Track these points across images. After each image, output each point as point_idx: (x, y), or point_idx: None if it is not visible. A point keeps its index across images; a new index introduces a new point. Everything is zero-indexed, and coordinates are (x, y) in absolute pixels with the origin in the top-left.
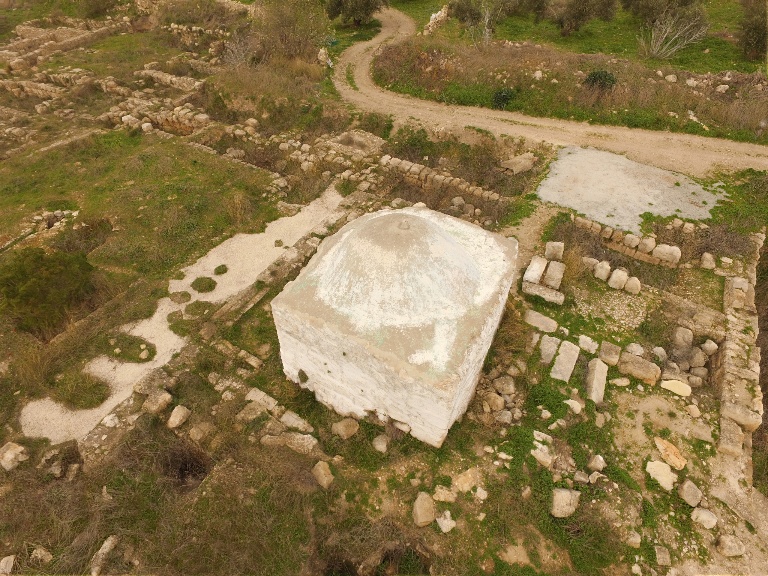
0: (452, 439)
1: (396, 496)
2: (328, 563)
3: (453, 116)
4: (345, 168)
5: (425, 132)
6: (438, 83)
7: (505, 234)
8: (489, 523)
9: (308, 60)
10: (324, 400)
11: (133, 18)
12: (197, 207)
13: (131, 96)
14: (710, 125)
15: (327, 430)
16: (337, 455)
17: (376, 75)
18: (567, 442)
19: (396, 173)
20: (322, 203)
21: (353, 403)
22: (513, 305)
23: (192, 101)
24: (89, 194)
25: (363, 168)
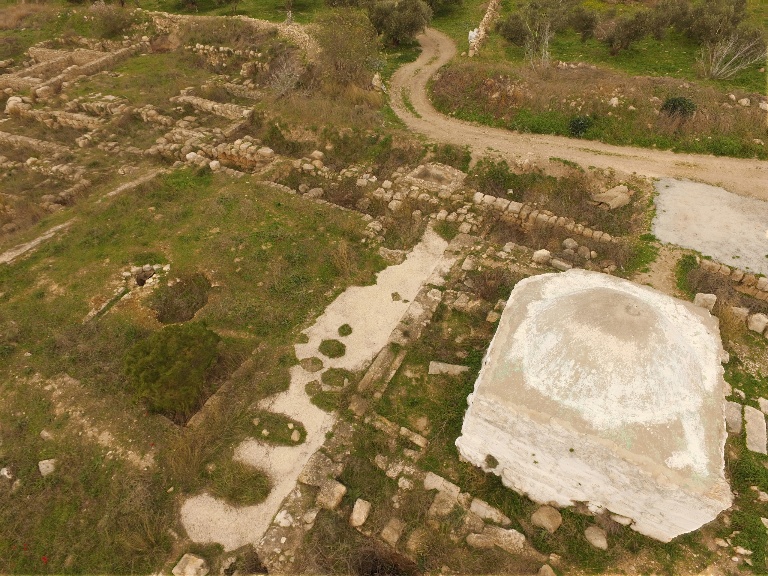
0: None
1: None
2: None
3: (532, 146)
4: (433, 205)
5: (506, 164)
6: (507, 110)
7: (639, 282)
8: None
9: (362, 86)
10: (517, 487)
11: (152, 37)
12: (298, 257)
13: (175, 126)
14: None
15: (527, 521)
16: (552, 553)
17: (437, 101)
18: None
19: (492, 211)
20: (426, 248)
21: (557, 493)
22: None
23: (242, 130)
24: (175, 245)
25: (458, 207)
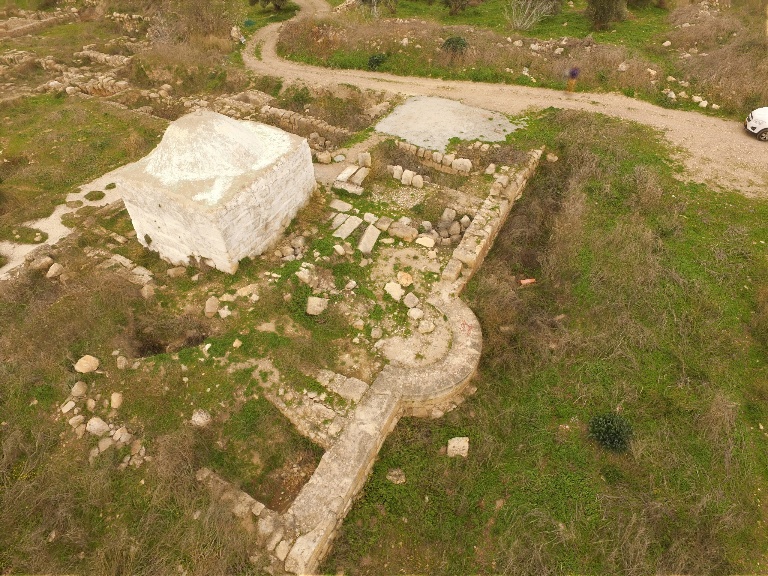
0: (244, 269)
1: (196, 302)
2: (143, 343)
3: (333, 77)
4: None
5: (307, 90)
6: (326, 52)
7: (337, 153)
8: (255, 313)
9: (222, 37)
10: (163, 255)
11: (80, 9)
12: (100, 145)
13: None
14: (538, 78)
15: (163, 274)
16: (164, 285)
17: (278, 48)
18: (332, 273)
19: (273, 119)
20: None
21: (180, 252)
22: (319, 193)
23: (121, 74)
24: (13, 139)
25: (246, 116)
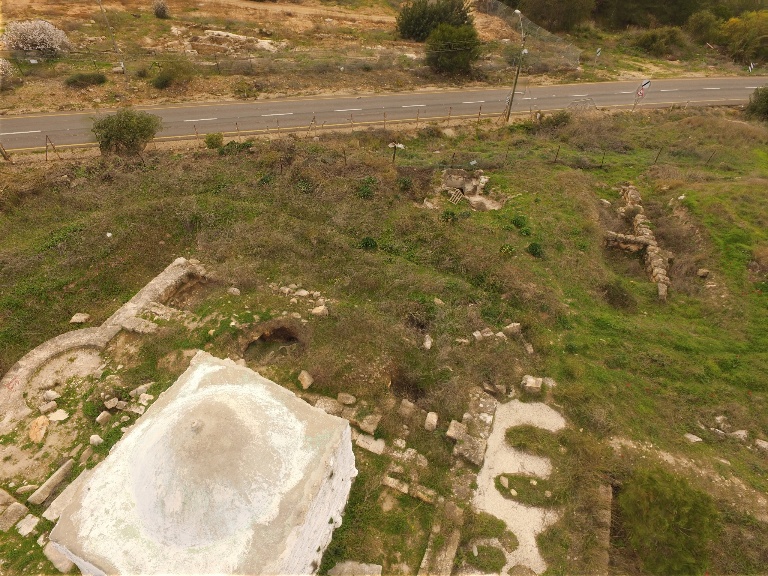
0: None
1: None
2: None
3: None
4: None
5: None
6: None
7: None
8: None
9: None
10: None
11: None
12: None
13: None
14: None
15: None
16: None
17: None
18: None
19: None
20: None
21: None
22: None
23: None
24: None
25: None
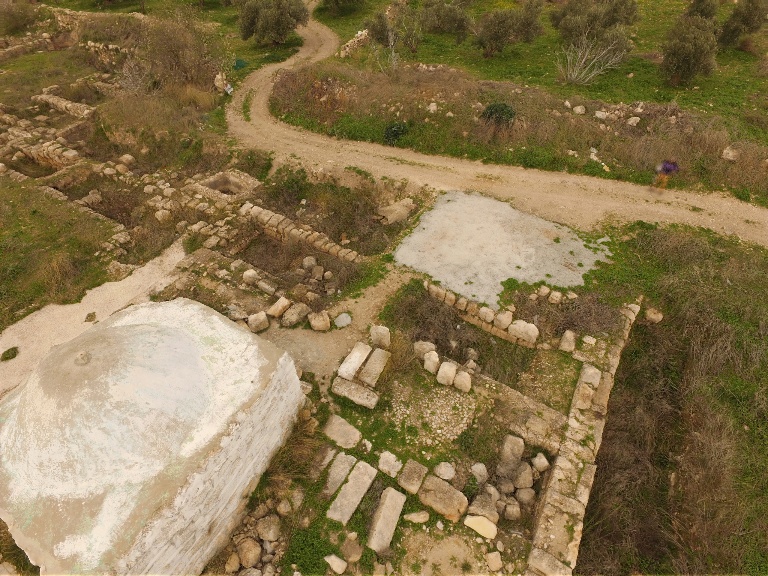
0: None
1: None
2: None
3: (338, 153)
4: (207, 216)
5: (305, 172)
6: (331, 115)
7: (339, 309)
8: None
9: (204, 87)
10: None
11: (54, 34)
12: (12, 271)
13: (17, 125)
14: (611, 165)
15: None
16: None
17: (271, 104)
18: None
19: (255, 224)
20: (160, 263)
21: None
22: (308, 413)
23: (79, 131)
24: None
25: (219, 219)
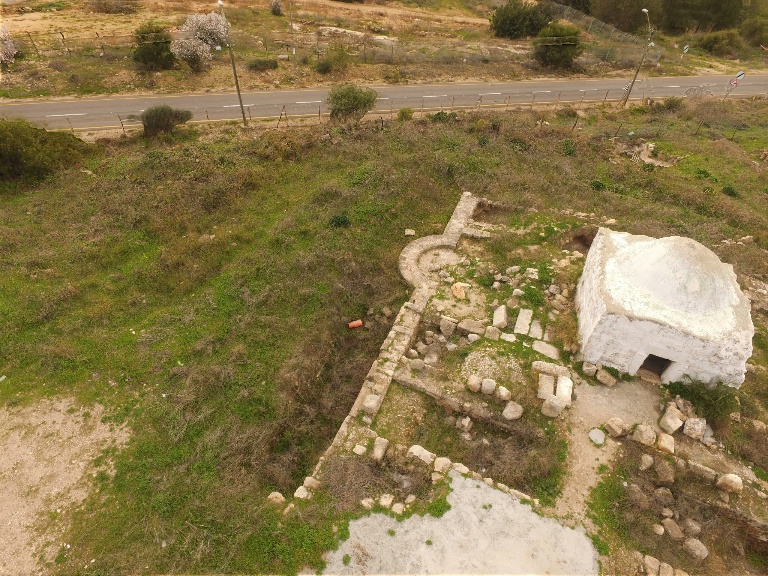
0: None
1: None
2: None
3: None
4: None
5: None
6: None
7: (609, 448)
8: None
9: None
10: None
11: None
12: None
13: None
14: None
15: None
16: None
17: None
18: None
19: None
20: None
21: None
22: (574, 347)
23: None
24: None
25: None
